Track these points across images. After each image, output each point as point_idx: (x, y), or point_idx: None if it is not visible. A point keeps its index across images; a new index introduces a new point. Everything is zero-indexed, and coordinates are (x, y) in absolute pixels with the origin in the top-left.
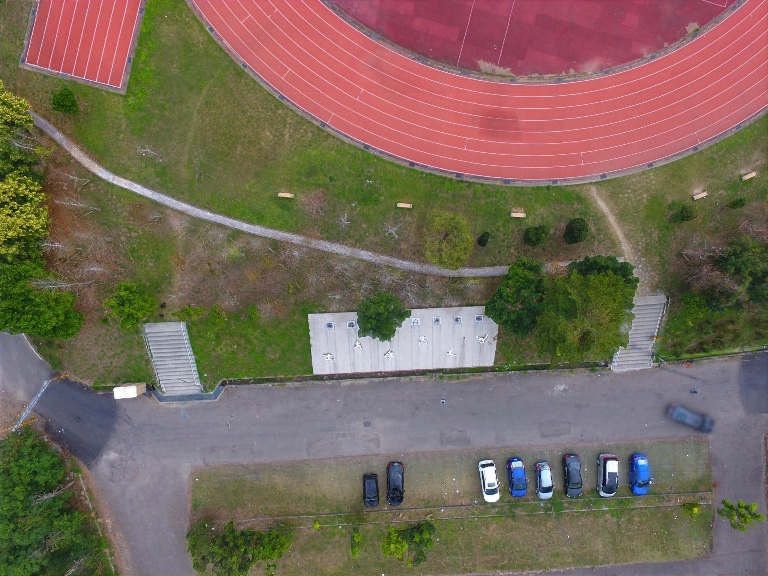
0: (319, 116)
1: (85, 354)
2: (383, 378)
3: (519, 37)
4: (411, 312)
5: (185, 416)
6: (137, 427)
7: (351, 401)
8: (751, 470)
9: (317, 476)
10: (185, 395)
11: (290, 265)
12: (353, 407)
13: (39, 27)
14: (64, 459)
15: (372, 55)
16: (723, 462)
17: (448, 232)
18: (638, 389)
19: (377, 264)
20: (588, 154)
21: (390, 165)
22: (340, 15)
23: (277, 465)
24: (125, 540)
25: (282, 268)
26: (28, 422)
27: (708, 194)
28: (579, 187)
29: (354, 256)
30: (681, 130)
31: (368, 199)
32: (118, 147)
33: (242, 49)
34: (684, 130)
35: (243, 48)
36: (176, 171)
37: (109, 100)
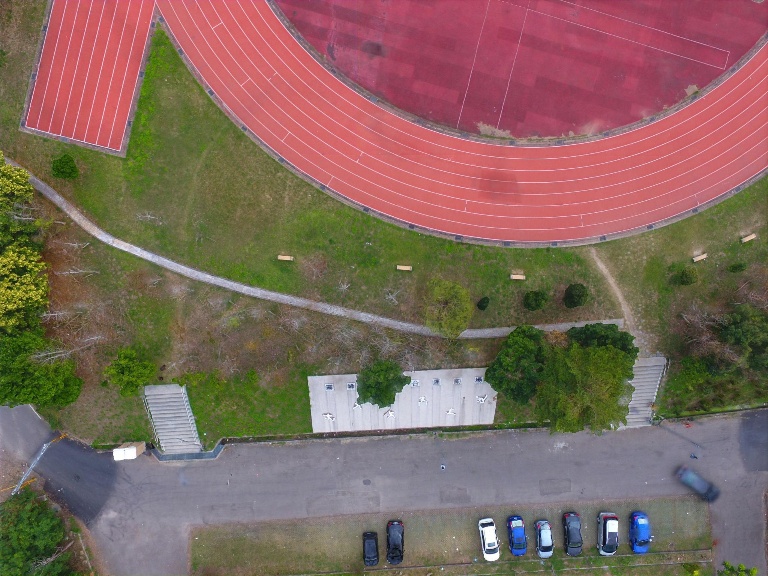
0: (319, 179)
1: (85, 415)
2: (383, 436)
3: (519, 100)
4: (411, 375)
5: (185, 475)
6: (137, 486)
7: (351, 459)
8: (751, 528)
9: (317, 534)
10: (185, 454)
11: (290, 327)
12: (353, 465)
13: (39, 91)
14: (63, 518)
15: (372, 118)
16: (723, 520)
17: (448, 300)
18: (638, 447)
19: (377, 326)
20: (588, 216)
21: (390, 227)
22: (340, 78)
23: (277, 523)
24: None
25: (282, 330)
26: (27, 483)
27: (708, 256)
28: (579, 249)
29: (354, 318)
30: (681, 192)
31: (368, 261)
32: (118, 210)
33: (242, 112)
34: (684, 192)
35: (243, 111)
36: (176, 234)
37: (109, 163)
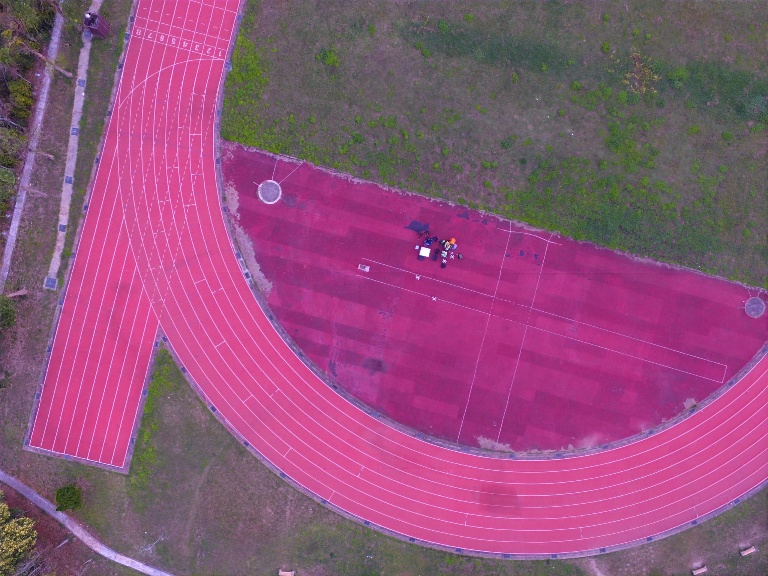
0: (320, 494)
1: None
2: None
3: (518, 414)
4: None
5: None
6: None
7: None
8: None
9: None
10: None
11: None
12: None
13: (43, 411)
14: None
15: (373, 432)
16: None
17: None
18: None
19: None
20: (587, 529)
21: (390, 540)
22: (341, 393)
23: None
24: None
25: None
26: None
27: (707, 568)
28: (579, 560)
29: None
30: (680, 505)
31: (368, 575)
32: (120, 525)
33: (244, 428)
34: (683, 505)
35: (245, 427)
36: (178, 549)
37: (112, 480)
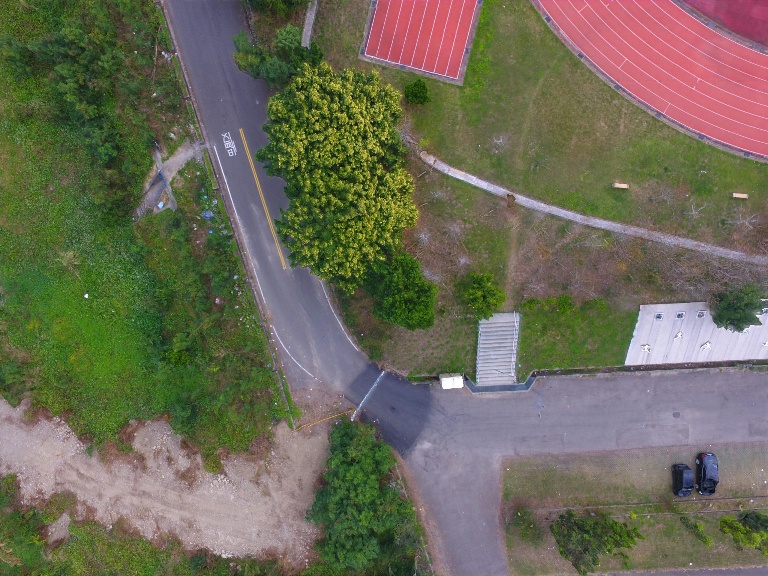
0: (655, 106)
1: (410, 345)
2: (693, 369)
3: None
4: None
5: (497, 406)
6: (450, 417)
7: (661, 392)
8: None
9: (626, 466)
10: (497, 386)
11: (623, 256)
12: (663, 398)
13: (379, 18)
14: None
15: (709, 44)
16: None
17: None
18: None
19: (709, 255)
20: None
21: (724, 155)
22: (678, 3)
23: (587, 455)
24: (438, 528)
25: (615, 259)
26: None
27: None
28: None
29: (687, 247)
30: None
31: (702, 189)
32: (454, 138)
33: (579, 39)
34: None
35: (580, 38)
36: (511, 162)
37: (446, 91)
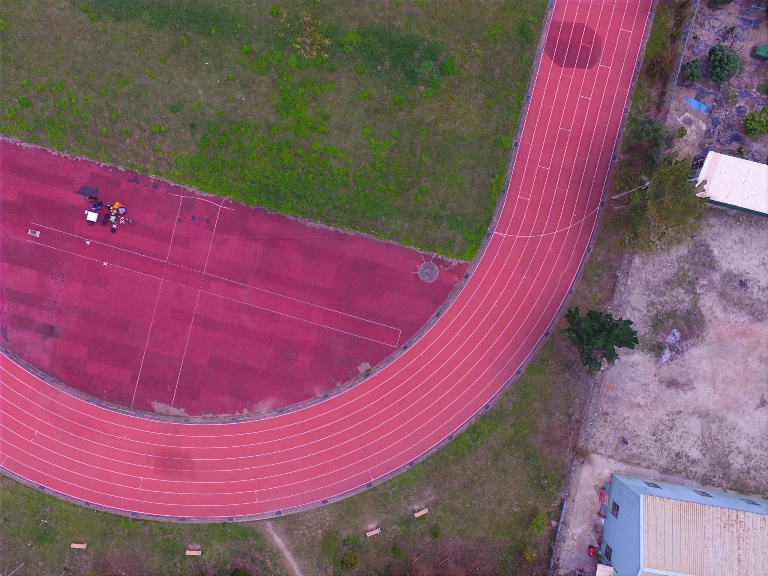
0: None
1: None
2: None
3: (192, 378)
4: None
5: None
6: None
7: None
8: None
9: None
10: None
11: None
12: None
13: None
14: None
15: (46, 397)
16: None
17: None
18: None
19: None
20: (262, 492)
21: (66, 504)
22: (13, 359)
23: None
24: None
25: None
26: None
27: (382, 530)
28: (255, 523)
29: None
30: (354, 468)
31: (43, 539)
32: None
33: None
34: (357, 468)
35: None
36: None
37: None
